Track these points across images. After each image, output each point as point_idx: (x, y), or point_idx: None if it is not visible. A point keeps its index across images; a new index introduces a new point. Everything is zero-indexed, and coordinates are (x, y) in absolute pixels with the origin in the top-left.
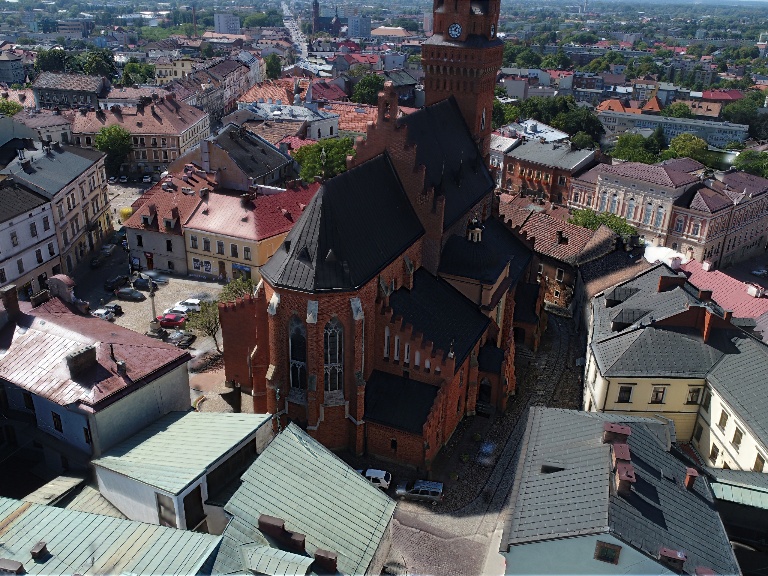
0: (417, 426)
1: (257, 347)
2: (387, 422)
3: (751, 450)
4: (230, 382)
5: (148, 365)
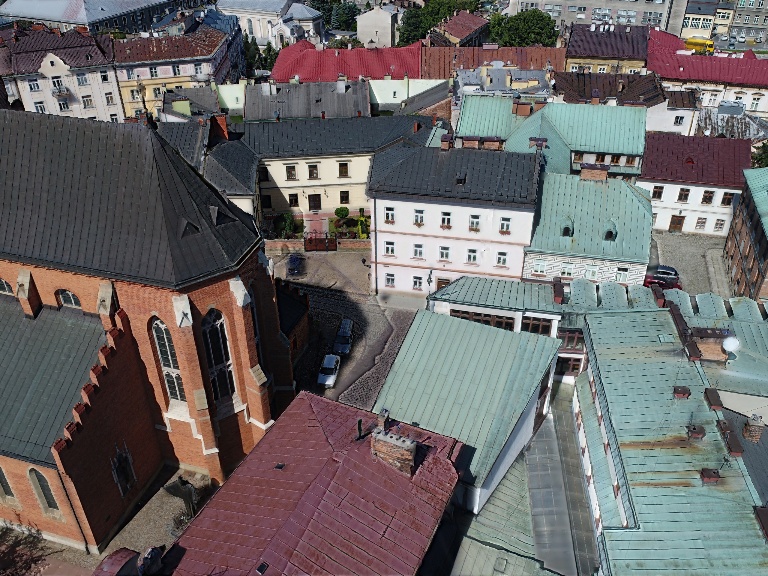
0: (298, 308)
1: (204, 389)
2: (289, 328)
3: (333, 167)
4: (103, 540)
5: (353, 414)
